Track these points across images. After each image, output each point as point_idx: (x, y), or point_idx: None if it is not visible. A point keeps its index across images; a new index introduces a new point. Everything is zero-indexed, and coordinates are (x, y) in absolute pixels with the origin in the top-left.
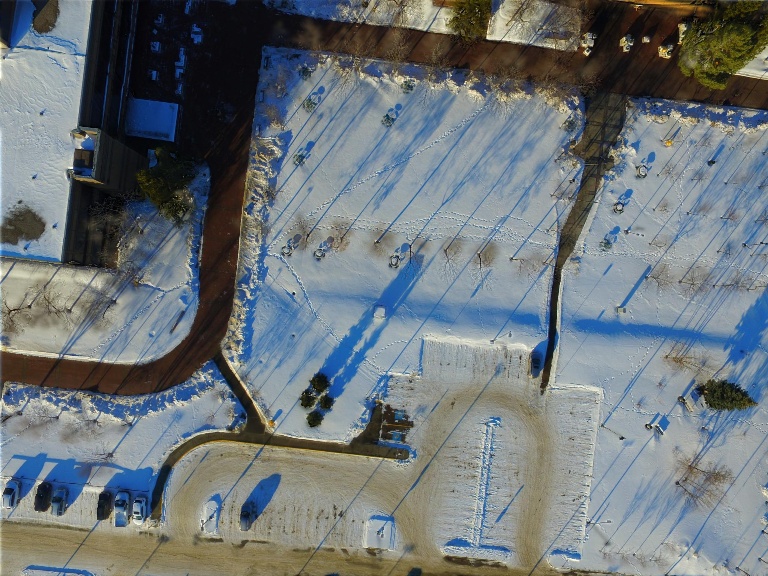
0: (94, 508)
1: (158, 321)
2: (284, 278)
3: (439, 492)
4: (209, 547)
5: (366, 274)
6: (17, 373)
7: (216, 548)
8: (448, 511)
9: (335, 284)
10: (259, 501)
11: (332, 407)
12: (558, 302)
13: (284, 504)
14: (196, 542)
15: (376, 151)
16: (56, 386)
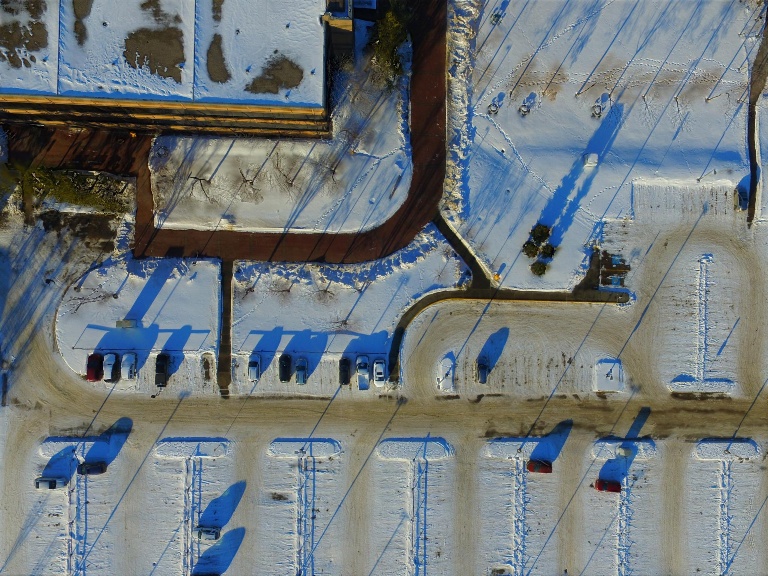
0: (333, 376)
1: (377, 188)
2: (492, 136)
3: (661, 331)
4: (447, 405)
5: (570, 126)
6: (245, 251)
7: (454, 405)
8: (671, 349)
9: (542, 138)
10: (491, 355)
11: (553, 257)
12: (755, 138)
13: (514, 356)
14: (434, 401)
15: (569, 5)
16: (284, 260)
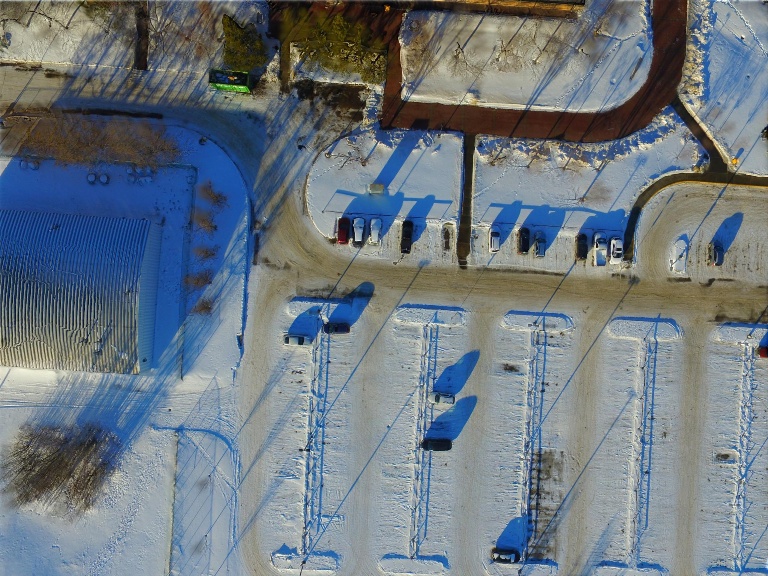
0: (569, 252)
1: (618, 68)
2: (733, 23)
3: None
4: (678, 287)
5: None
6: (487, 126)
7: (685, 287)
8: None
9: None
10: (724, 240)
11: None
12: None
13: (748, 242)
14: (666, 282)
15: None
16: (524, 137)
